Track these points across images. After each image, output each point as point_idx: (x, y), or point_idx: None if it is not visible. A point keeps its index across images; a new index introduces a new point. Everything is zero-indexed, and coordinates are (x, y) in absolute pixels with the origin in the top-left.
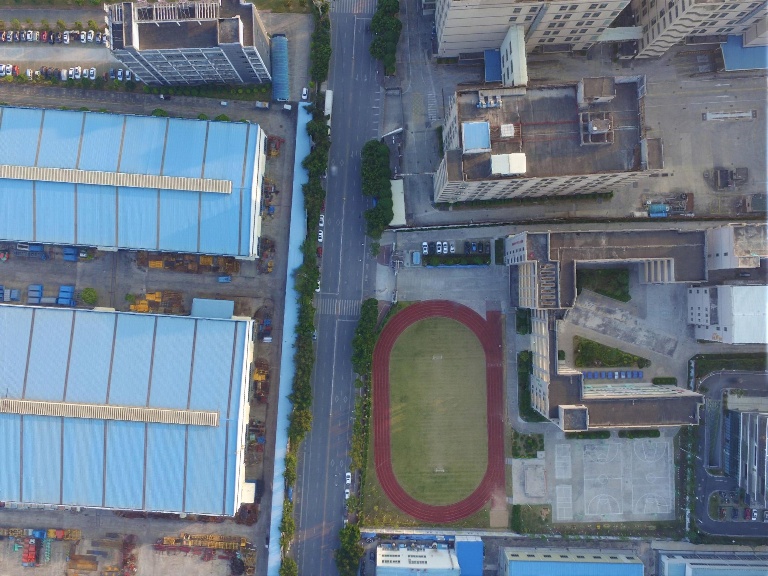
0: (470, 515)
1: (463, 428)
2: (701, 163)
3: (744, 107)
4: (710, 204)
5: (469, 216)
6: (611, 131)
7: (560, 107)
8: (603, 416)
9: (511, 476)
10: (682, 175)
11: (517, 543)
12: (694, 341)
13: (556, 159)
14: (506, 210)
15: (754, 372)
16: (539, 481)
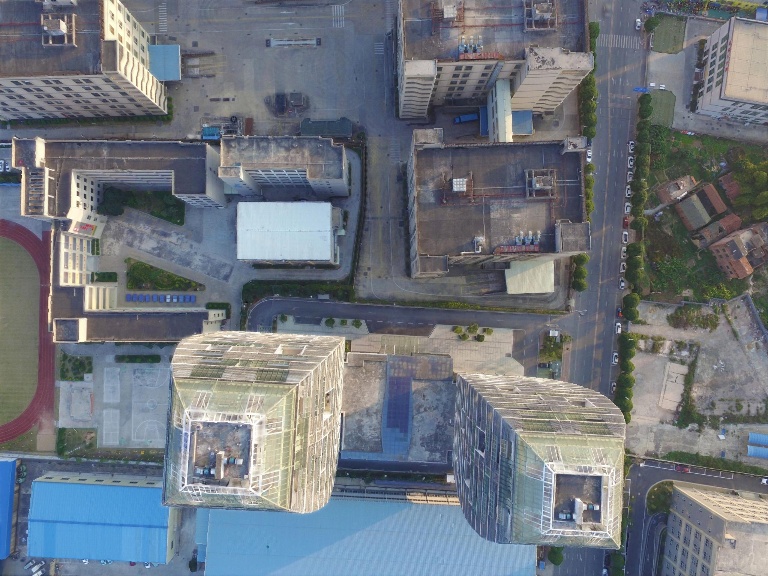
0: (16, 438)
1: (13, 349)
2: (263, 89)
3: (309, 35)
4: (270, 130)
5: (27, 135)
6: (71, 33)
7: (26, 9)
8: (107, 330)
9: (58, 399)
10: (243, 100)
11: (61, 467)
12: (250, 267)
13: (20, 60)
14: (65, 130)
15: (307, 299)
16: (84, 404)
